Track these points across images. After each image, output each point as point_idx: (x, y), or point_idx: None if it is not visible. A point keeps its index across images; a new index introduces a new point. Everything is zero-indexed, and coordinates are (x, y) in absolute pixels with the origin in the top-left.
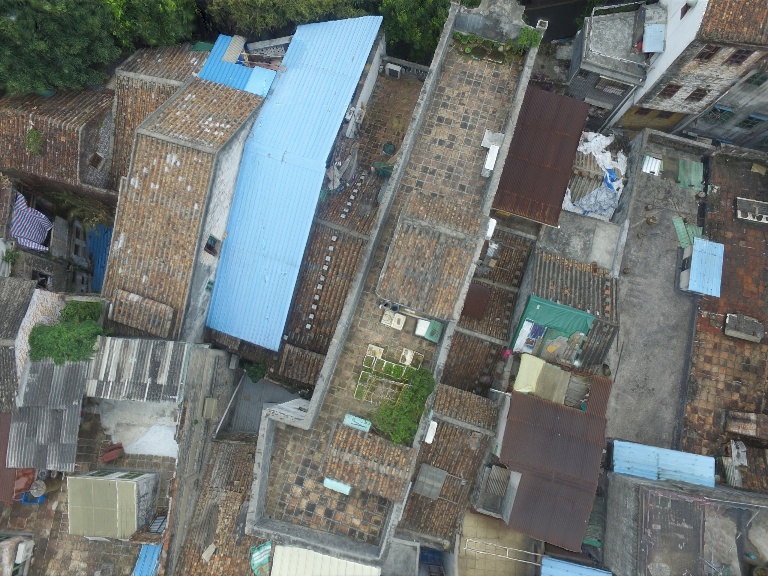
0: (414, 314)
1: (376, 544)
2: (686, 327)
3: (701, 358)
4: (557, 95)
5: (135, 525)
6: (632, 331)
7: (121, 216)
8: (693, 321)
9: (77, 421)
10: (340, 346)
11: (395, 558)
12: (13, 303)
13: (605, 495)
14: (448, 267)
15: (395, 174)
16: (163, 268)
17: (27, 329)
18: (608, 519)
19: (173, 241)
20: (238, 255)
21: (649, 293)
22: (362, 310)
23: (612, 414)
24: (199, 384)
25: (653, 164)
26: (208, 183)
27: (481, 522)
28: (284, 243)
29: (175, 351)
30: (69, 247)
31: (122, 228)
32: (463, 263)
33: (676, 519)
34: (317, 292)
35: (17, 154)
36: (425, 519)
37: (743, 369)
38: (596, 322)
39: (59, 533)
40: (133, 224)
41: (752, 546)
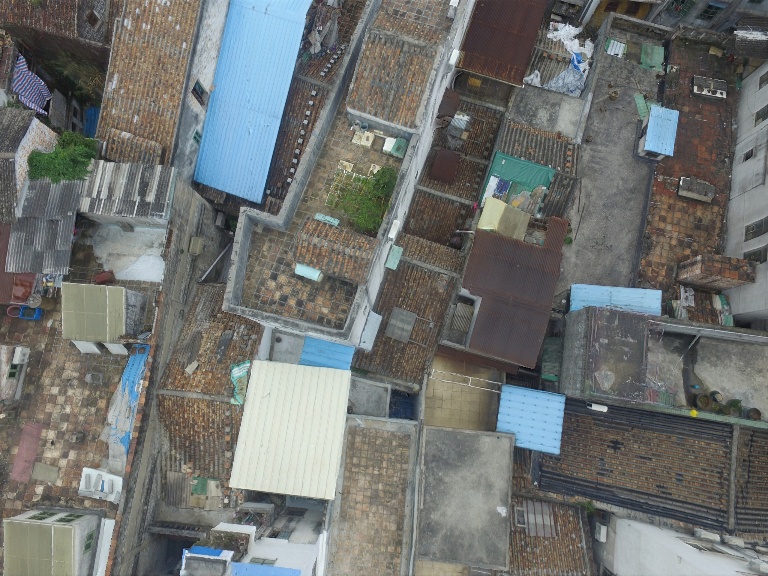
0: (382, 134)
1: (342, 329)
2: (643, 190)
3: (656, 217)
4: None
5: (123, 329)
6: (593, 194)
7: (115, 57)
8: (650, 184)
9: (71, 230)
10: (313, 160)
11: (367, 398)
12: (14, 126)
13: (563, 335)
14: (411, 75)
15: (367, 9)
16: (153, 108)
17: (26, 150)
18: (564, 353)
19: (163, 80)
20: (224, 108)
21: (609, 160)
22: (335, 132)
23: (572, 268)
24: (185, 218)
25: (617, 47)
26: (195, 22)
27: (448, 367)
28: (267, 95)
29: (163, 173)
30: (67, 122)
31: (116, 69)
32: (424, 71)
33: (622, 334)
34: (298, 147)
35: (19, 8)
36: (396, 363)
37: (695, 227)
38: (557, 175)
39: (53, 347)
40: (126, 65)
41: (697, 378)
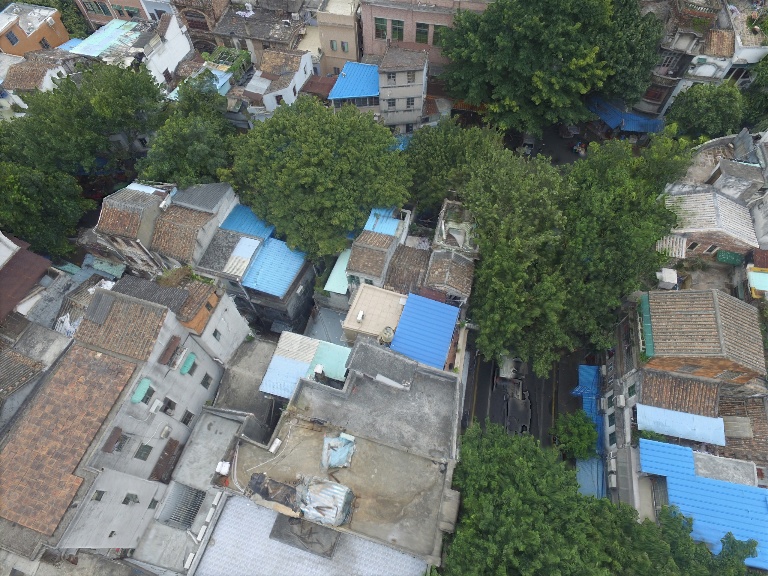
0: None
1: None
2: None
3: None
4: (37, 255)
5: None
6: None
7: None
8: None
9: None
10: None
11: None
12: None
13: None
14: None
15: None
16: None
17: None
18: None
19: None
20: None
21: None
22: None
23: None
24: None
25: None
26: None
27: None
28: None
29: None
30: None
31: None
32: None
33: None
34: None
35: None
36: None
37: None
38: None
39: None
40: None
41: None
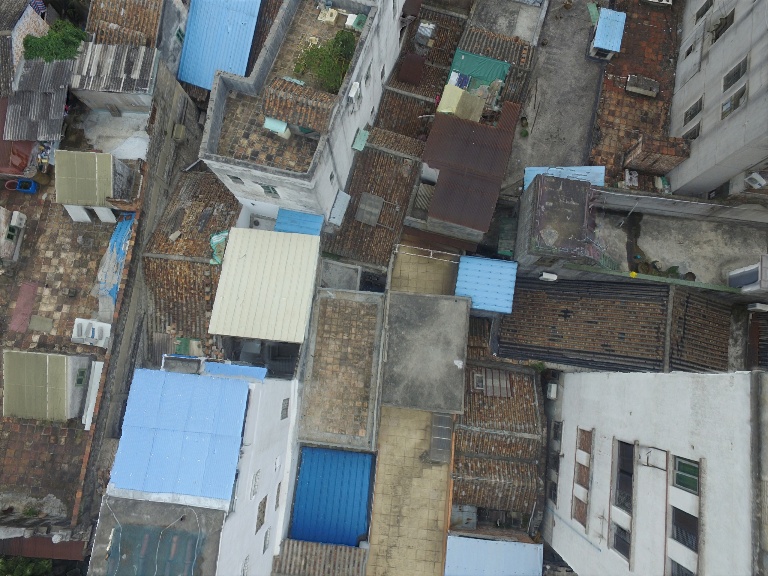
0: (345, 12)
1: None
2: (594, 88)
3: (606, 112)
4: None
5: (111, 193)
6: (548, 92)
7: None
8: (600, 82)
9: (63, 101)
10: (282, 33)
11: (339, 279)
12: (10, 11)
13: (517, 214)
14: None
15: None
16: (138, 1)
17: (22, 33)
18: (518, 229)
19: None
20: (205, 8)
21: (563, 61)
22: (302, 11)
23: (528, 159)
24: (169, 104)
25: None
26: None
27: (414, 251)
28: None
29: (147, 54)
30: None
31: None
32: None
33: (566, 198)
34: None
35: None
36: (366, 247)
37: (641, 120)
38: (512, 69)
39: (48, 216)
40: None
41: (639, 250)
